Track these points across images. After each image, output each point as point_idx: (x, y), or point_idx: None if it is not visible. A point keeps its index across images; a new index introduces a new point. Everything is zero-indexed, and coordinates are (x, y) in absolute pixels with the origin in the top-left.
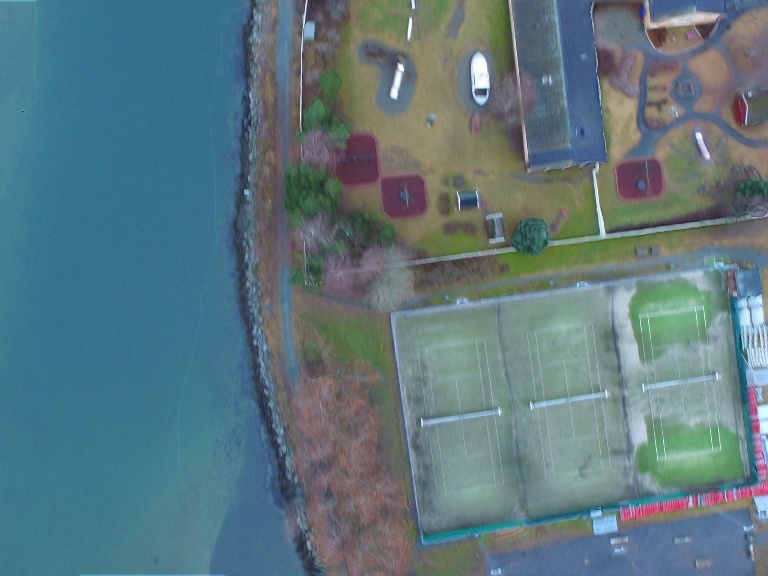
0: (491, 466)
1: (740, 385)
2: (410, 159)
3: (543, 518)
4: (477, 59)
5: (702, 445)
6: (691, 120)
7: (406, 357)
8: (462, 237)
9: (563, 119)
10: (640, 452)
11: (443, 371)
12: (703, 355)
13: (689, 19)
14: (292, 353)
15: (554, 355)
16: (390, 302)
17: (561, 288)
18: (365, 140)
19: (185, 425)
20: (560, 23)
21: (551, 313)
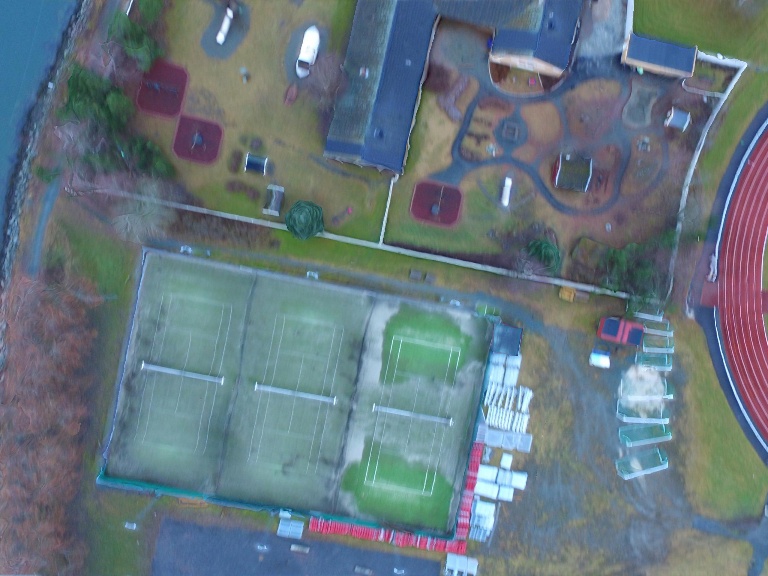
0: (197, 431)
1: (472, 438)
2: (216, 106)
3: (231, 500)
4: (311, 32)
5: (414, 484)
6: (506, 164)
7: (148, 296)
8: (243, 199)
9: (366, 115)
10: (350, 469)
11: (181, 322)
12: (444, 396)
13: (531, 64)
14: (38, 254)
15: (296, 345)
16: (136, 233)
17: (324, 282)
18: (177, 73)
19: None
20: (394, 22)
21: (306, 303)
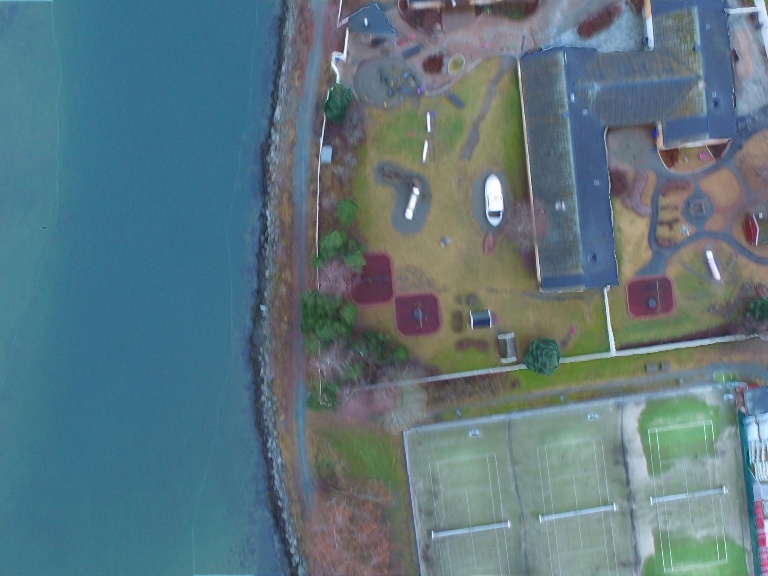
0: None
1: (747, 498)
2: (424, 278)
3: None
4: (491, 181)
5: (709, 557)
6: (702, 239)
7: (418, 471)
8: (474, 353)
9: (576, 245)
10: (647, 564)
11: (454, 484)
12: (711, 469)
13: (701, 142)
14: (306, 467)
15: (563, 469)
16: (403, 424)
17: (571, 404)
18: (380, 260)
19: (200, 533)
20: (574, 150)
21: (561, 428)
